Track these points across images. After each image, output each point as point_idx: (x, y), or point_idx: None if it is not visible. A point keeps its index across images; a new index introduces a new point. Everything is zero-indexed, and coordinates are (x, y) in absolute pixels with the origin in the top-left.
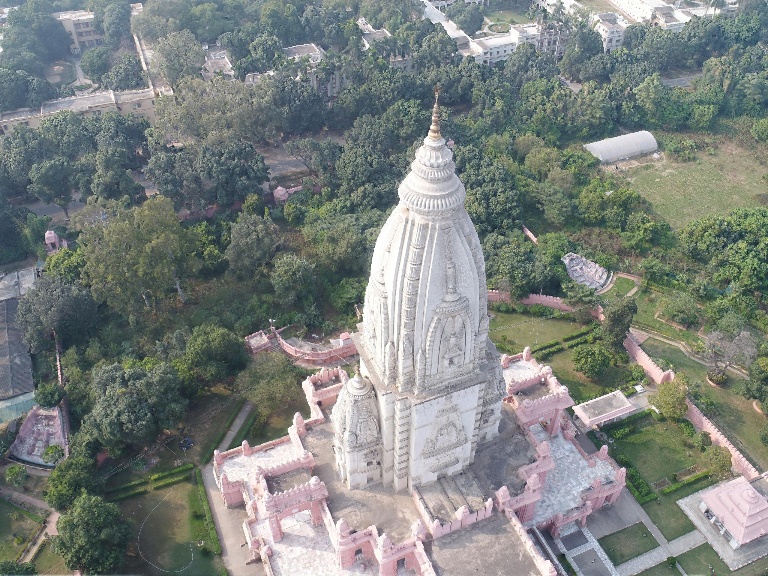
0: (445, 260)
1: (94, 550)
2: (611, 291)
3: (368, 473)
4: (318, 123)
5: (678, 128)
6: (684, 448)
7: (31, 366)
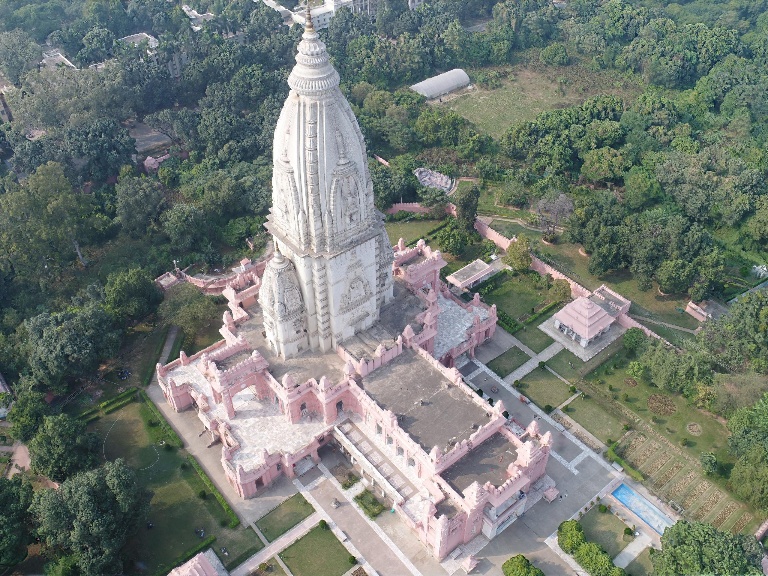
0: (334, 131)
1: (72, 456)
2: (457, 192)
3: (298, 342)
4: (169, 100)
5: (483, 64)
6: (536, 291)
7: None
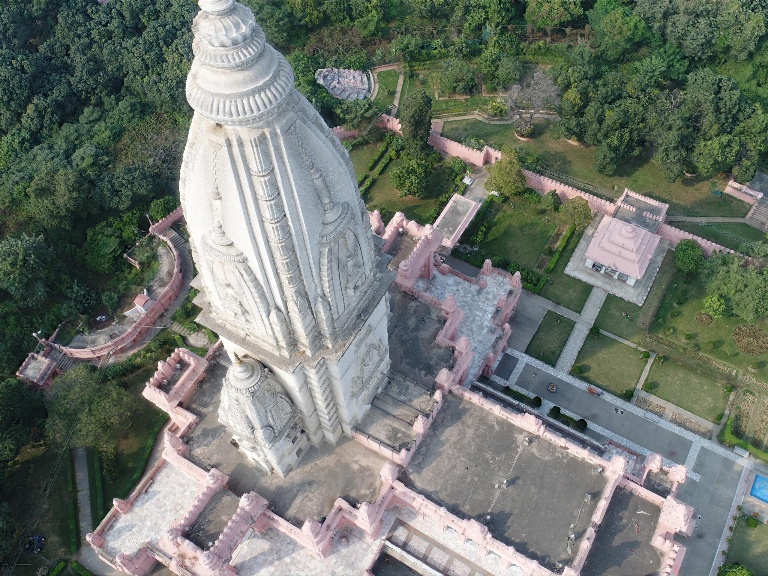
0: (307, 171)
1: None
2: (381, 92)
3: (296, 449)
4: None
5: None
6: (539, 217)
7: None
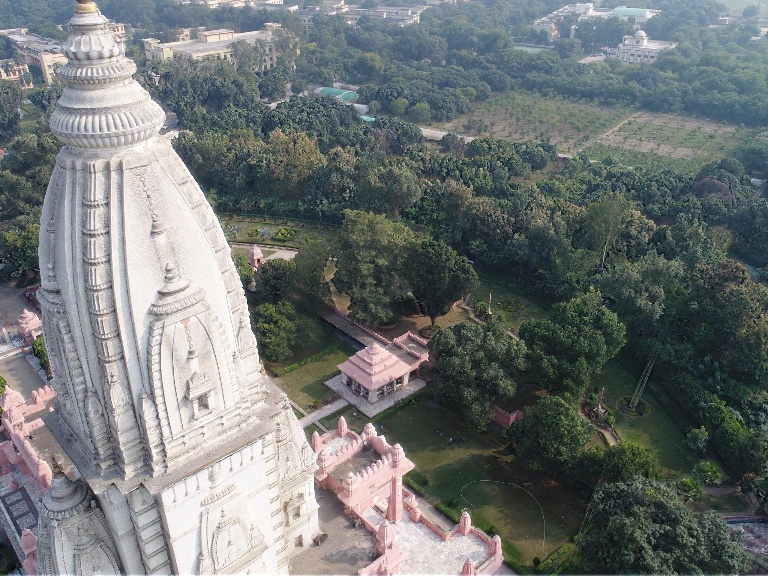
0: None
1: None
2: None
3: None
4: None
5: None
6: None
7: None
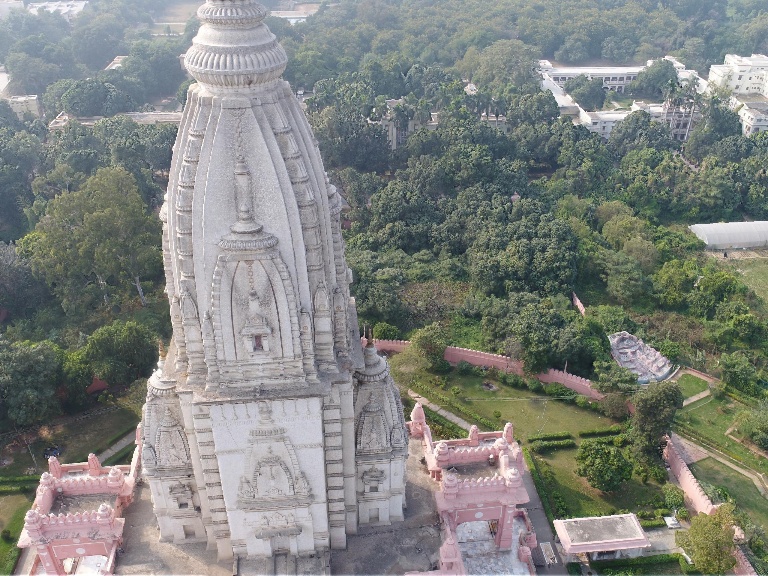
0: (233, 161)
1: None
2: None
3: (183, 521)
4: (381, 166)
5: None
6: None
7: None
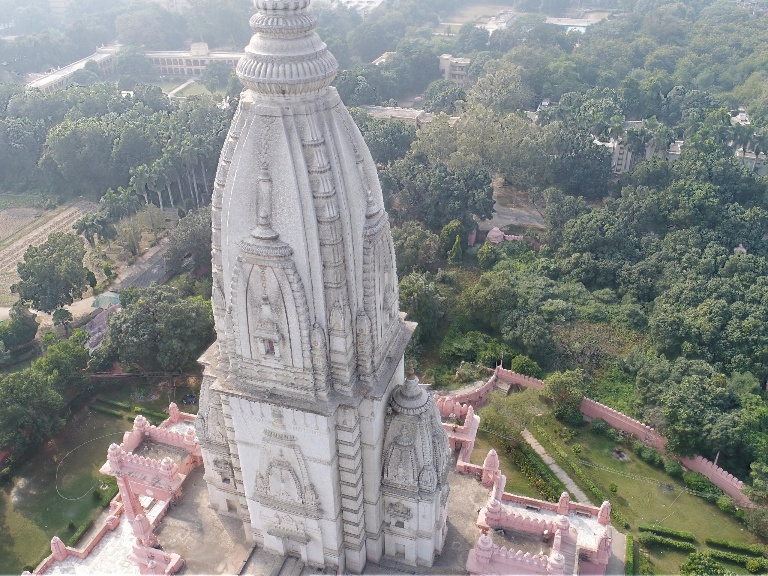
0: (259, 166)
1: (2, 419)
2: None
3: (227, 494)
4: (600, 191)
5: None
6: None
7: (163, 281)
